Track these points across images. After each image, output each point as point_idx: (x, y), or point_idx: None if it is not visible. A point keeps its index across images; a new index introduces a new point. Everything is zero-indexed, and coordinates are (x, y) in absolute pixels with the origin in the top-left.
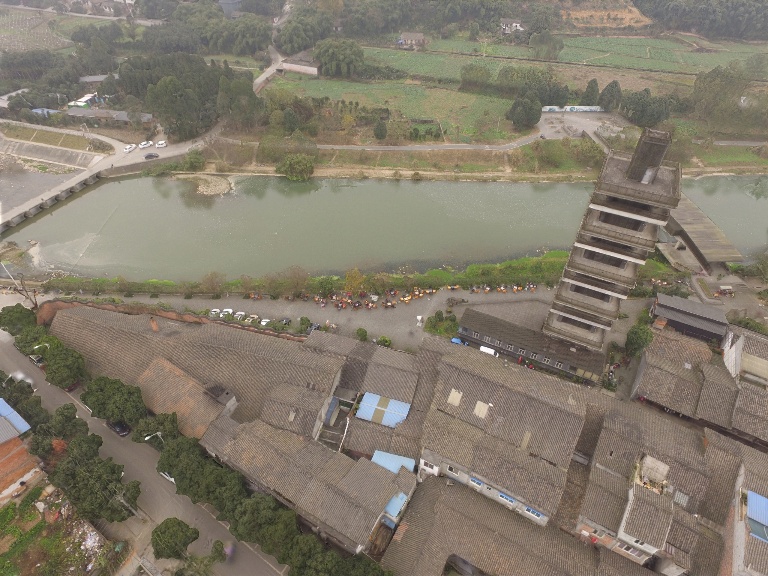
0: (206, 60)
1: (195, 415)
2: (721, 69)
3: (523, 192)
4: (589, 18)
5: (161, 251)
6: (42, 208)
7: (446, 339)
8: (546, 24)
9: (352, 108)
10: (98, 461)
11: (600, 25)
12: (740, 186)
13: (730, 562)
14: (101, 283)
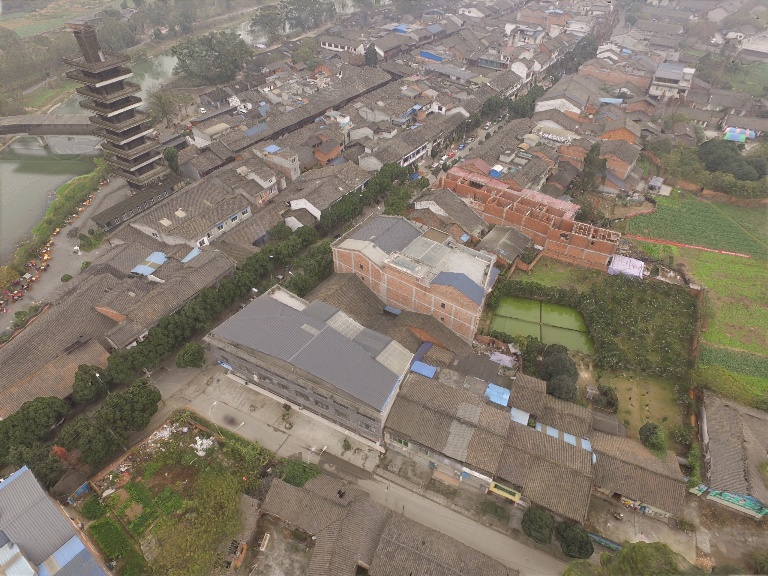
0: None
1: (87, 362)
2: None
3: None
4: None
5: None
6: None
7: (106, 242)
8: None
9: None
10: (99, 409)
11: None
12: None
13: (286, 168)
14: None
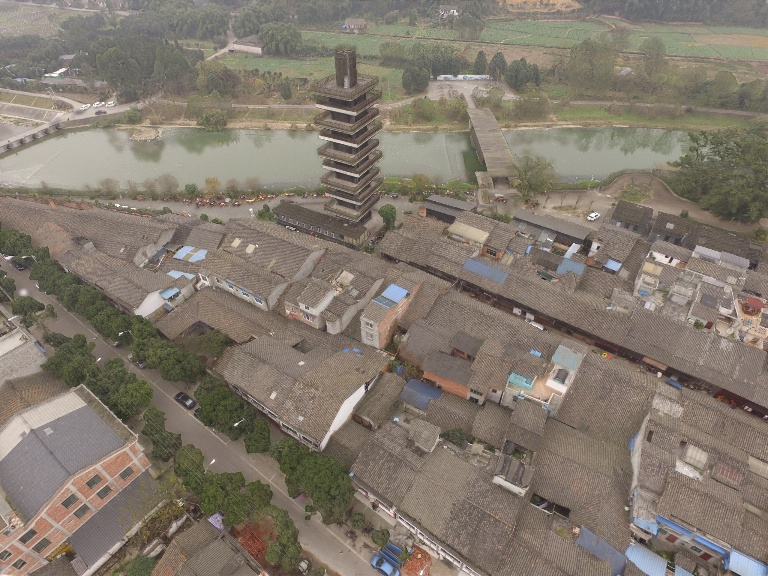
0: (172, 43)
1: (63, 252)
2: (588, 40)
3: (392, 139)
4: (523, 4)
5: (89, 175)
6: (9, 148)
7: None
8: (475, 9)
9: (275, 77)
10: None
11: (532, 10)
12: (581, 135)
13: None
14: (31, 188)
